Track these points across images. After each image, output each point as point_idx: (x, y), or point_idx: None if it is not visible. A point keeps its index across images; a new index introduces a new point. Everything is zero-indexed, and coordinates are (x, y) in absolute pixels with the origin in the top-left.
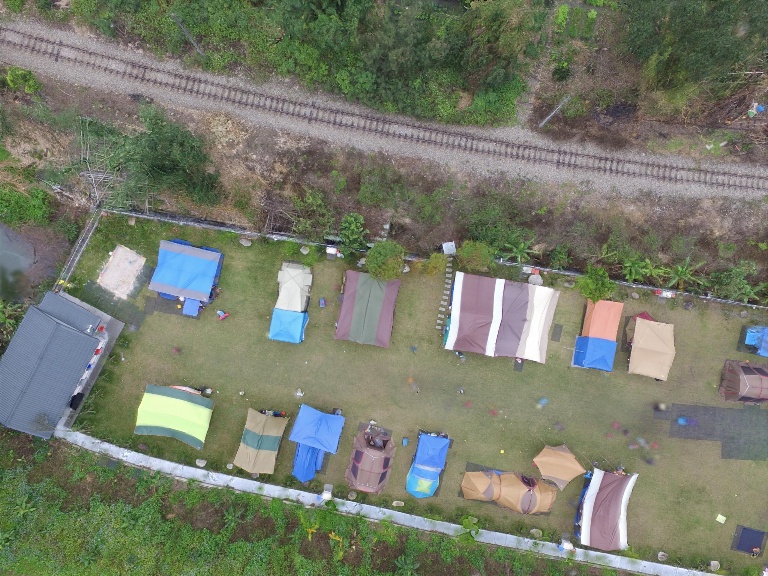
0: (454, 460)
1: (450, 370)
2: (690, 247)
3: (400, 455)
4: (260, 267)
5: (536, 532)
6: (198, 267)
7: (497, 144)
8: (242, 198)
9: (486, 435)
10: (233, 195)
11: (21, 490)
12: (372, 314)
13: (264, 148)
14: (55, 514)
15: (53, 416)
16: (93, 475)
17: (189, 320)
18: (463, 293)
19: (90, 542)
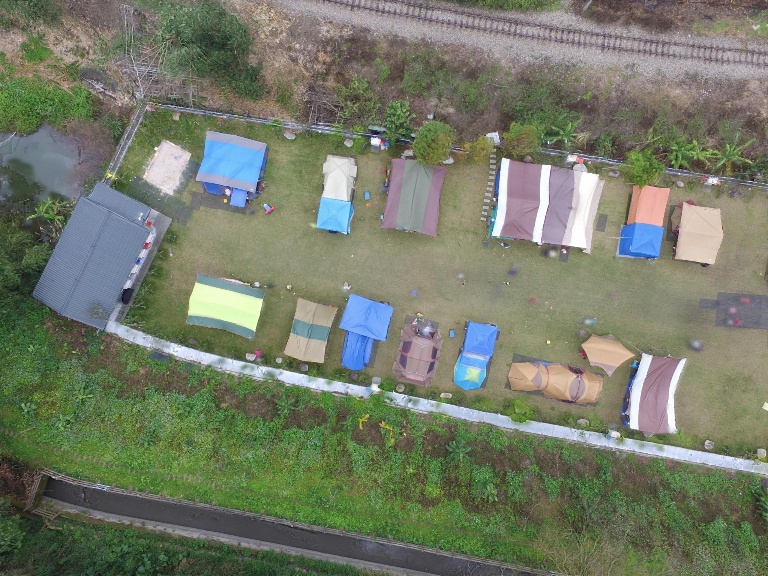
0: (500, 352)
1: (495, 262)
2: (736, 131)
3: (447, 347)
4: (304, 161)
5: (583, 422)
6: (245, 157)
7: (541, 28)
8: (285, 91)
9: (532, 326)
10: (275, 90)
11: (77, 379)
12: (419, 202)
13: (307, 36)
14: (112, 401)
15: (106, 306)
16: (146, 368)
17: (235, 215)
18: (509, 180)
19: (148, 426)
